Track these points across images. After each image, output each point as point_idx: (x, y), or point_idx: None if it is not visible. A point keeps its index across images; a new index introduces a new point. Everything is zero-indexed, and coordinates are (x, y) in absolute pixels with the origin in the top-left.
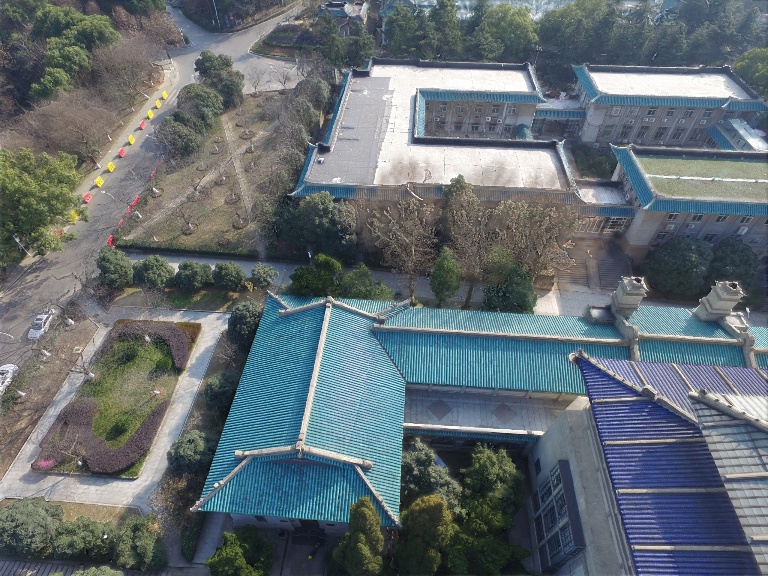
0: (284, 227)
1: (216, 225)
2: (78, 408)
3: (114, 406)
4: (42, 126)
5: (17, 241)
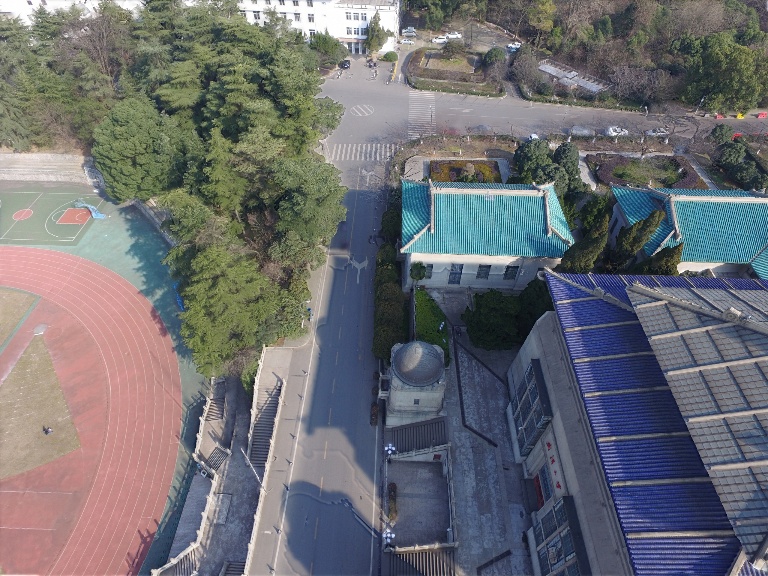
0: None
1: None
2: (623, 158)
3: (631, 171)
4: None
5: (702, 100)
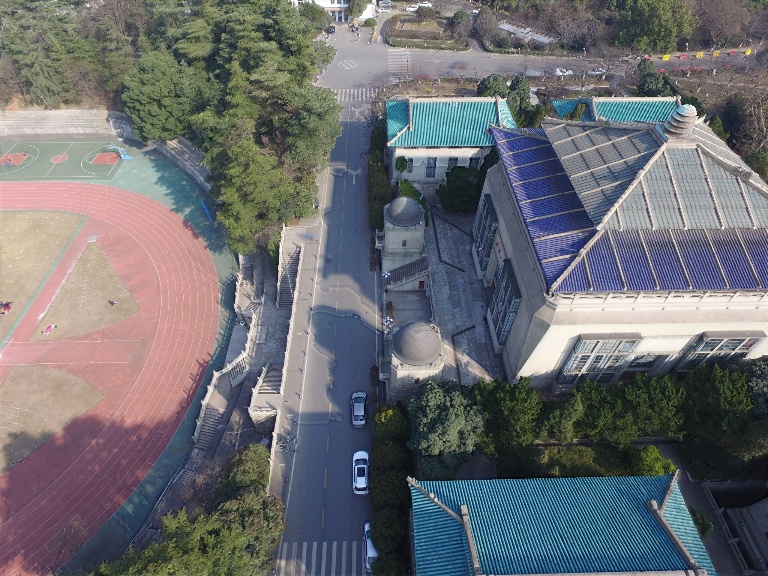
0: (729, 105)
1: (710, 99)
2: (566, 90)
3: None
4: (709, 3)
5: None
